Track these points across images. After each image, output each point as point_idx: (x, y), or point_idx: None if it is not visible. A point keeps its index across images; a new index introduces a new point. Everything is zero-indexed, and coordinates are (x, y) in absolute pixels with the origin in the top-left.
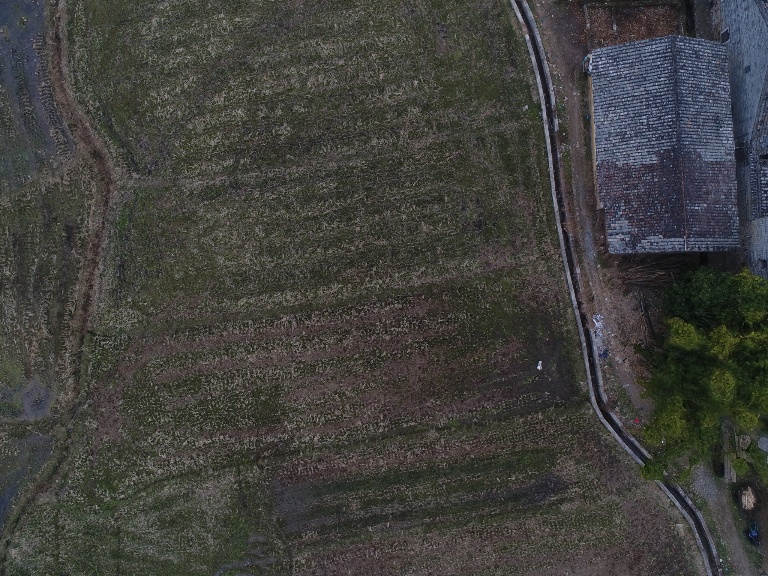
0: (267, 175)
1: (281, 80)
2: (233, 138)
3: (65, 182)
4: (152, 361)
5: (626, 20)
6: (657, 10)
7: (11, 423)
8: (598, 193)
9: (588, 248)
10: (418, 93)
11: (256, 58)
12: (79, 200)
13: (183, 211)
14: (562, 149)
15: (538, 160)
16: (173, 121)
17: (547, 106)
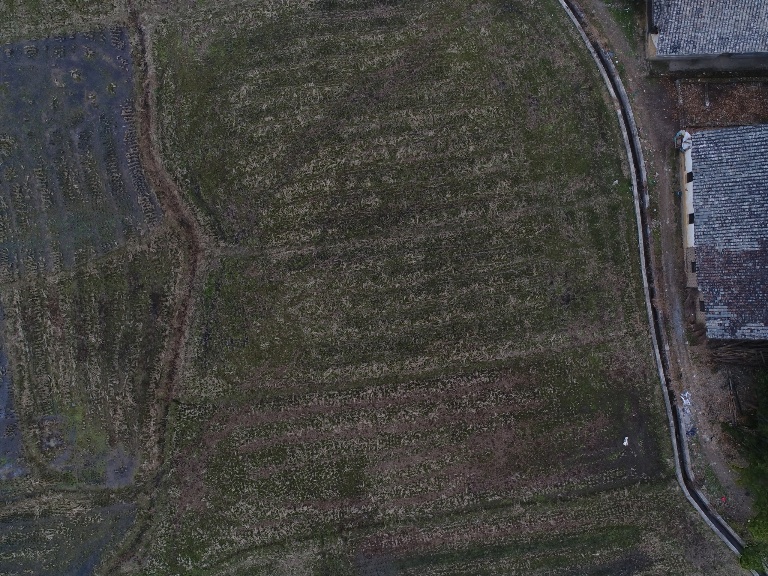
0: (355, 246)
1: (370, 150)
2: (321, 208)
3: (152, 250)
4: (237, 430)
5: (718, 96)
6: (750, 87)
7: (94, 490)
8: (696, 277)
9: (677, 325)
10: (508, 166)
11: (345, 128)
12: (166, 268)
13: (270, 280)
14: (652, 225)
15: (628, 235)
16: (261, 190)
17: (637, 181)
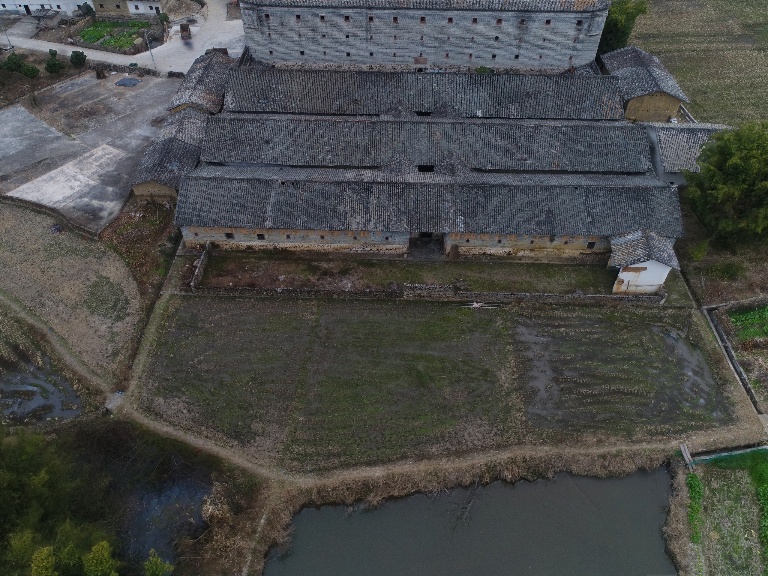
0: None
1: None
2: None
3: None
4: None
5: None
6: None
7: None
8: None
9: None
10: None
11: None
12: None
13: None
14: None
15: None
16: None
17: None
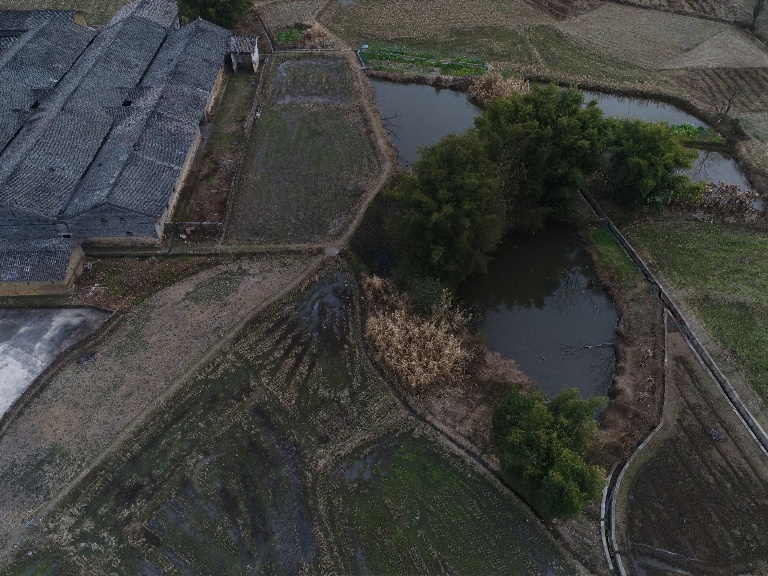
0: None
1: None
2: None
3: None
4: None
5: None
6: None
7: None
8: None
9: None
10: None
11: None
12: None
13: None
14: None
15: None
16: None
17: None
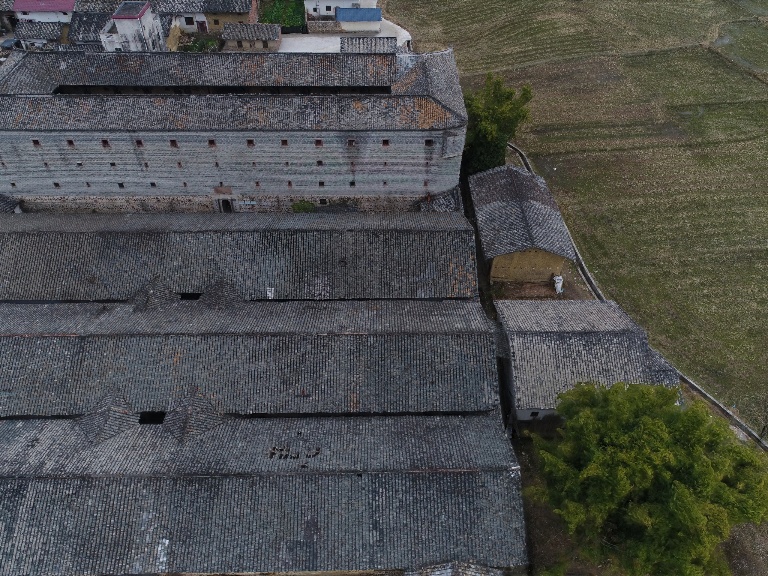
0: (760, 246)
1: None
2: None
3: None
4: None
5: None
6: None
7: None
8: None
9: None
10: None
11: None
12: None
13: None
14: None
15: (580, 246)
16: None
17: None
